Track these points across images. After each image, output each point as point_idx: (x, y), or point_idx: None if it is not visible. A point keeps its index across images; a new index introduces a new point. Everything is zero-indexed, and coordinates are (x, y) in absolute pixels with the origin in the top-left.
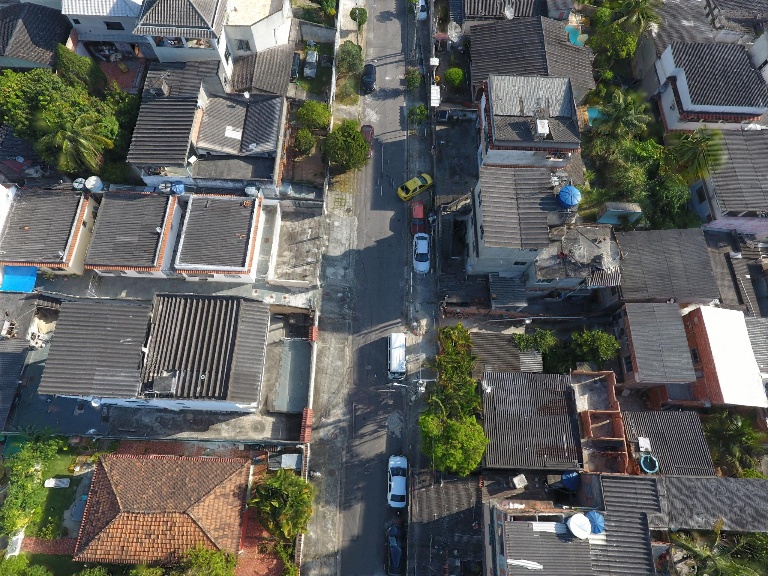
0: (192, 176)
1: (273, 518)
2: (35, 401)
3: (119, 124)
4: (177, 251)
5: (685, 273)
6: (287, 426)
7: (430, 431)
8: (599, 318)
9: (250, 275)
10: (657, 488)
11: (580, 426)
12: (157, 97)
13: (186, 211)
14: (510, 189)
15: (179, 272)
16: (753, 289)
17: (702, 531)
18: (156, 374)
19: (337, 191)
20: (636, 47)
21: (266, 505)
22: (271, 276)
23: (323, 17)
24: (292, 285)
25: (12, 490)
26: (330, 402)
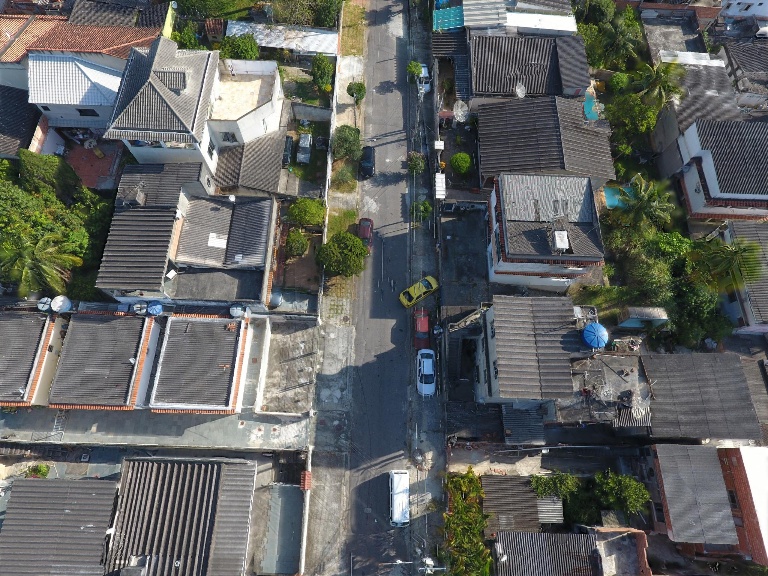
0: (170, 297)
1: None
2: None
3: (90, 234)
4: (153, 385)
5: (722, 407)
6: None
7: None
8: (624, 450)
9: None
10: None
11: None
12: (131, 206)
13: (164, 335)
14: (527, 323)
15: None
16: None
17: None
18: (123, 561)
19: (333, 296)
20: (656, 120)
21: None
22: (259, 403)
23: (318, 92)
24: (282, 415)
25: None
26: (325, 554)
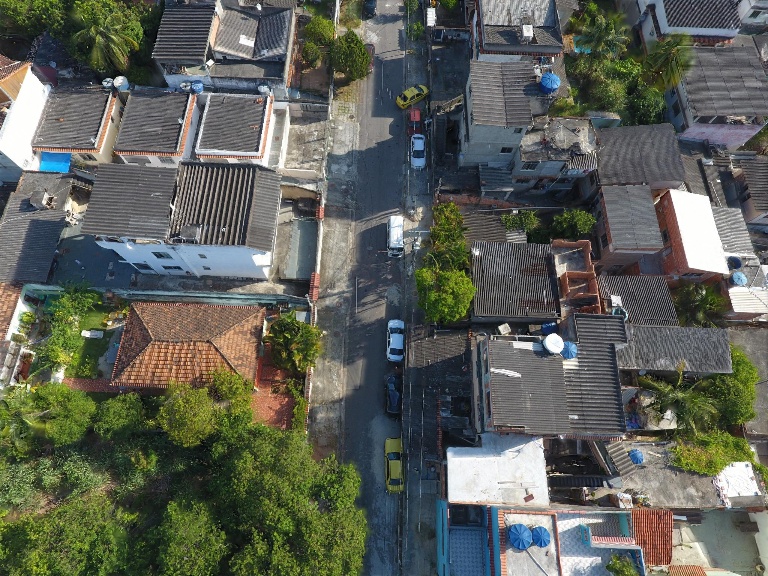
0: (210, 75)
1: (286, 349)
2: (71, 268)
3: (143, 31)
4: (197, 140)
5: (656, 161)
6: (296, 293)
7: (424, 279)
8: (579, 207)
9: (263, 163)
10: (624, 324)
11: (559, 288)
12: (178, 5)
13: (205, 107)
14: (497, 79)
15: (199, 157)
16: (724, 194)
17: (666, 372)
18: None
19: (341, 100)
20: None
21: (280, 337)
22: None
23: None
24: (300, 176)
25: (54, 332)
26: (335, 276)
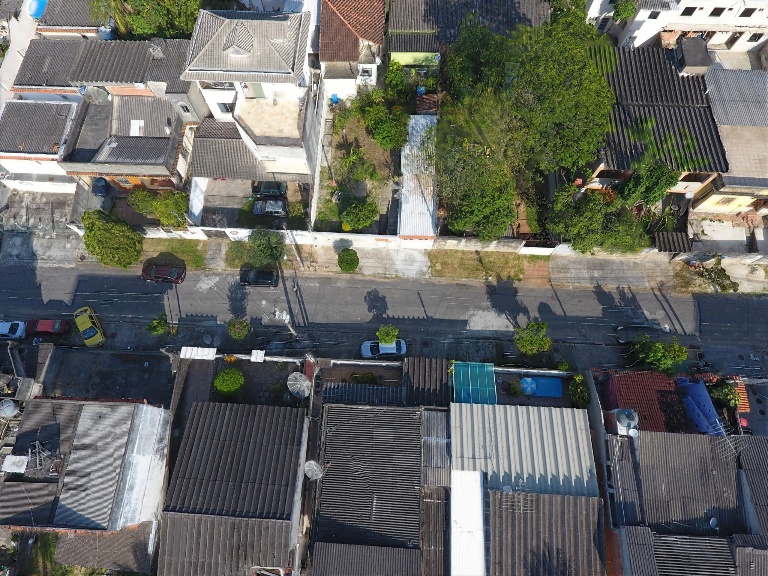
0: (83, 97)
1: None
2: None
3: None
4: None
5: None
6: None
7: None
8: None
9: (1, 163)
10: None
11: None
12: None
13: None
14: None
15: None
16: None
17: None
18: None
19: None
20: None
21: None
22: (17, 187)
23: None
24: (1, 204)
25: None
26: None
